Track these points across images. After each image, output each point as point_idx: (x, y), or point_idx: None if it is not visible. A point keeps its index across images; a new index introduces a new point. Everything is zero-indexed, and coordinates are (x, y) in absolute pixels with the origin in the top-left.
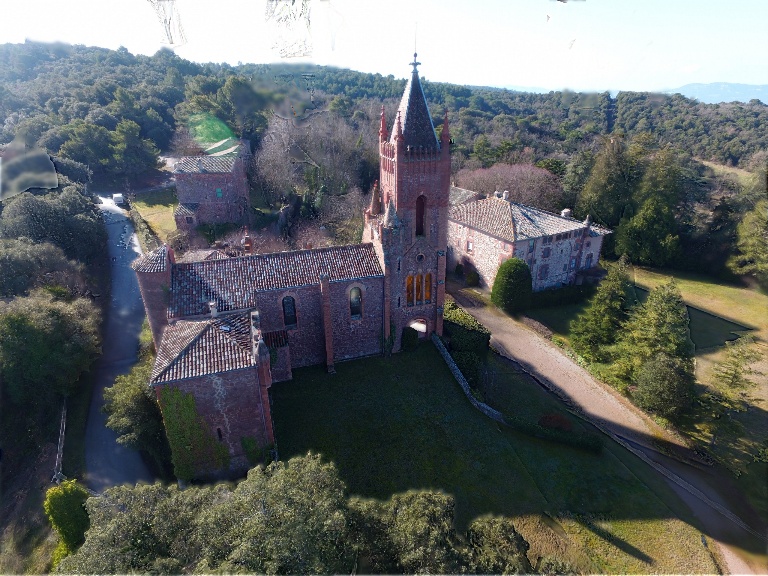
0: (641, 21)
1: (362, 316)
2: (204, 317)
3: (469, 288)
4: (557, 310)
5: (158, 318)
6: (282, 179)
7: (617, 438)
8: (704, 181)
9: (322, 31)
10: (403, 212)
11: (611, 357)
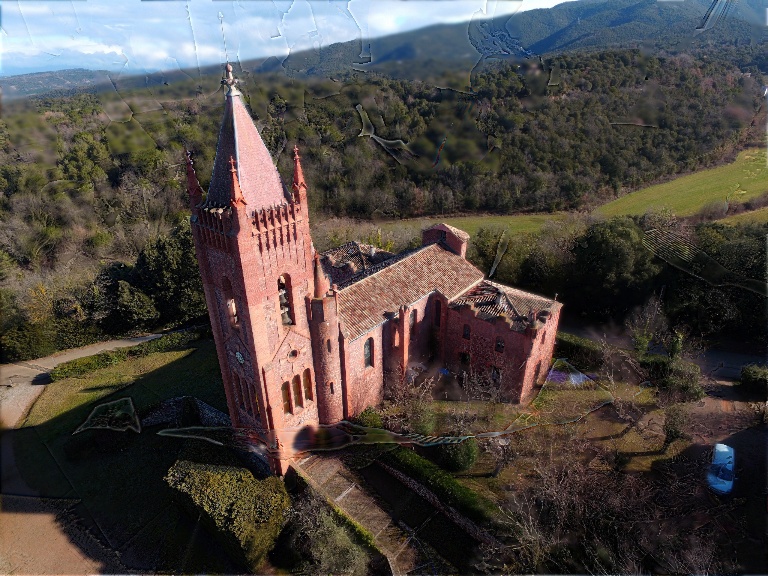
0: None
1: None
2: None
3: None
4: None
5: None
6: None
7: None
8: None
9: (458, 2)
10: None
11: None
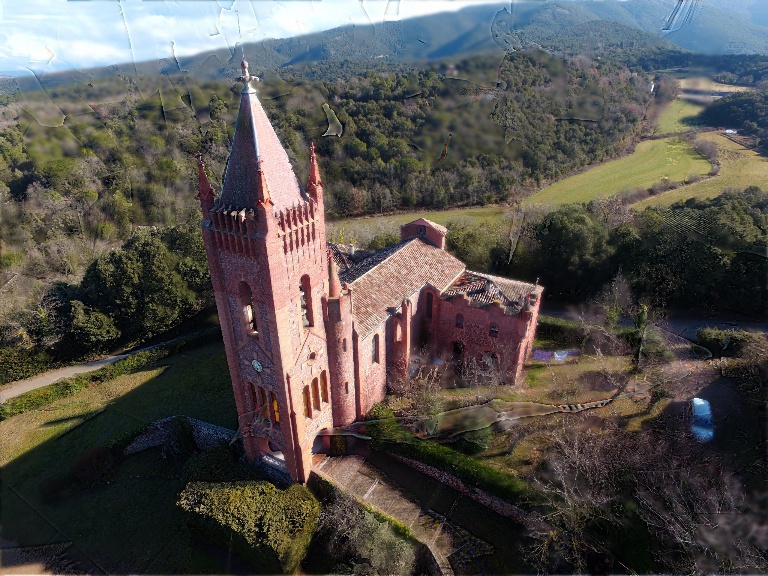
0: None
1: None
2: None
3: None
4: None
5: None
6: None
7: None
8: None
9: (482, 1)
10: None
11: None
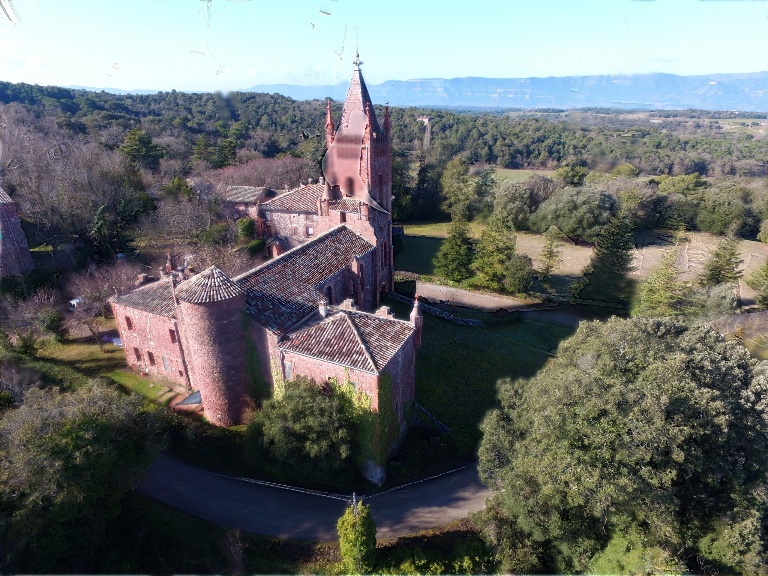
0: (372, 35)
1: (364, 290)
2: (300, 324)
3: None
4: (394, 262)
5: (234, 351)
6: (88, 200)
7: (554, 297)
8: (411, 154)
9: (229, 24)
10: (373, 191)
11: (480, 270)
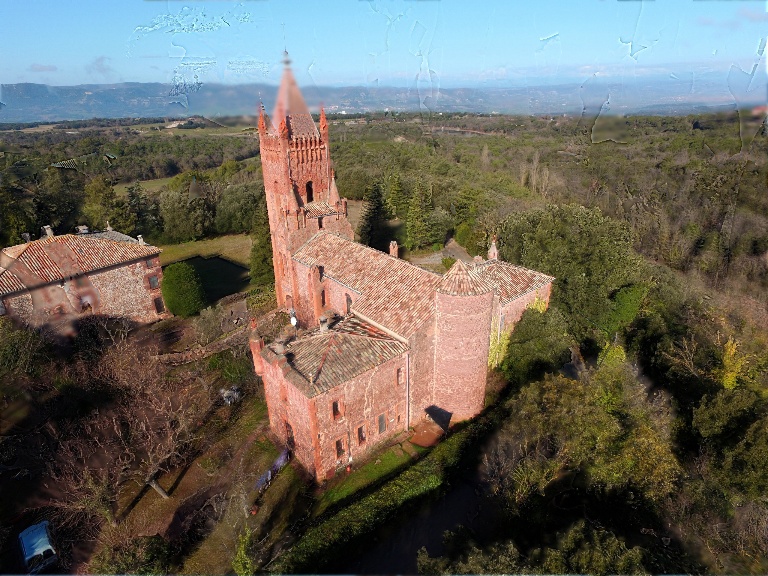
0: None
1: None
2: None
3: (130, 338)
4: None
5: None
6: None
7: None
8: None
9: None
10: None
11: None
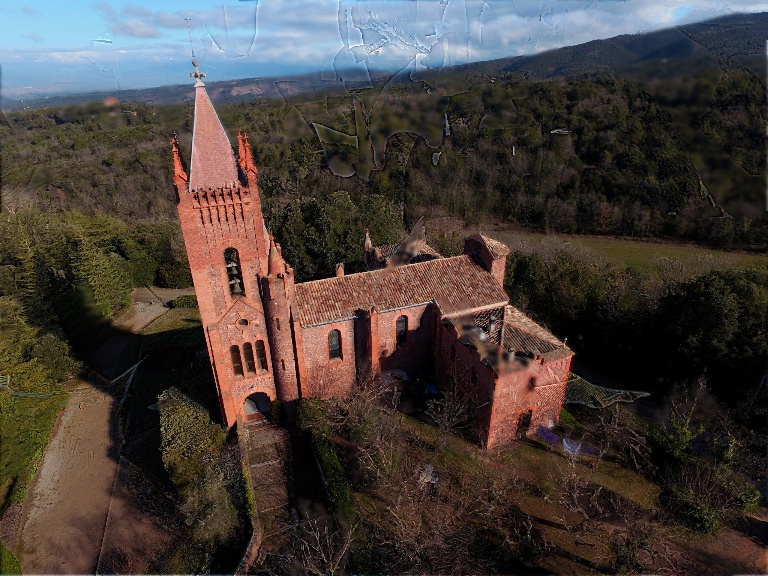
0: None
1: None
2: None
3: None
4: None
5: None
6: None
7: None
8: None
9: None
10: None
11: None
